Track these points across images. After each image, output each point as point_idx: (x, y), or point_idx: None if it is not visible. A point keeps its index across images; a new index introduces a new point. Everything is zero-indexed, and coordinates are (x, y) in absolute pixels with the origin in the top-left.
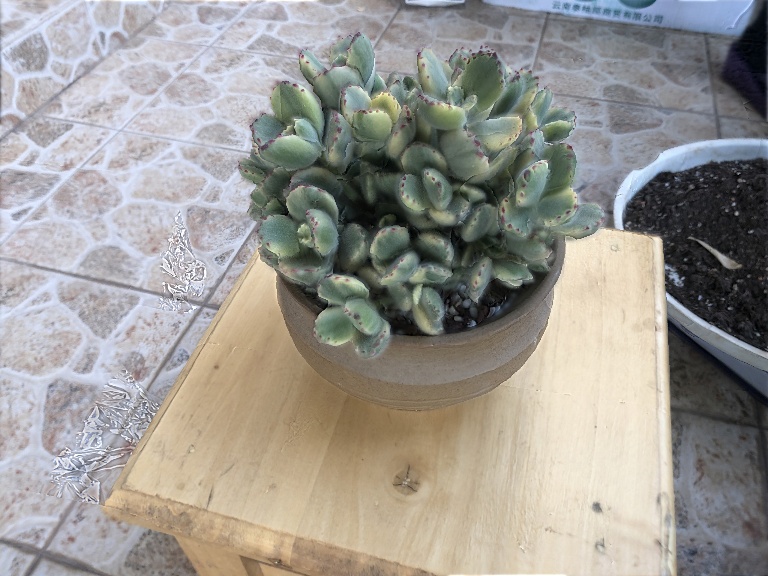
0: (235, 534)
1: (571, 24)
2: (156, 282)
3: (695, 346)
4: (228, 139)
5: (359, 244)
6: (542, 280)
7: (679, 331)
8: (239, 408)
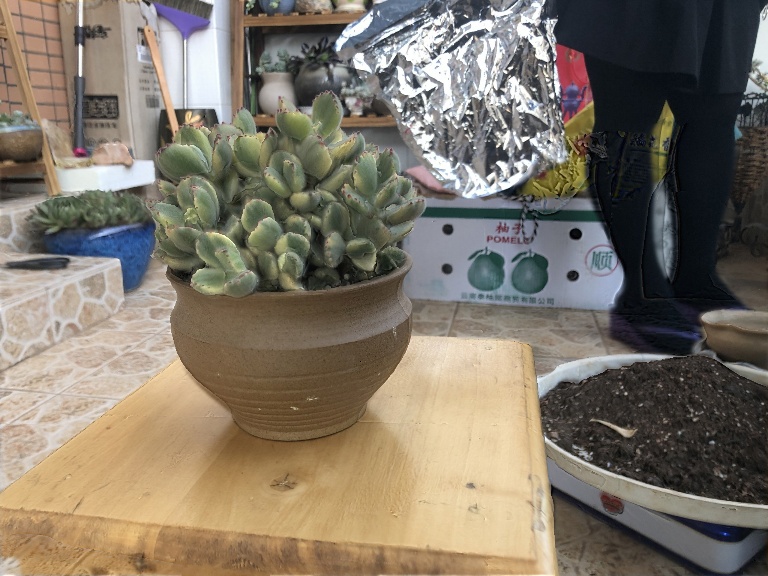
0: (98, 531)
1: (478, 308)
2: None
3: (623, 529)
4: None
5: (234, 224)
6: (391, 271)
7: (604, 516)
8: (124, 450)
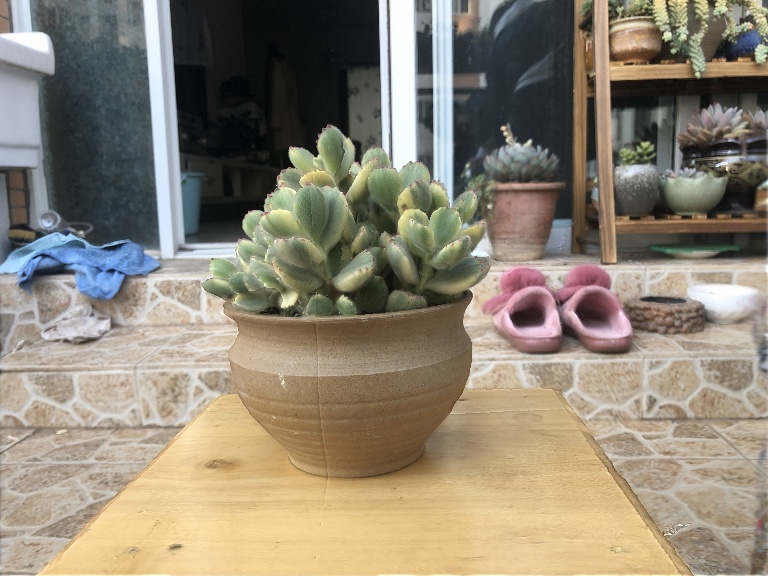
0: None
1: None
2: None
3: None
4: None
5: None
6: None
7: None
8: None
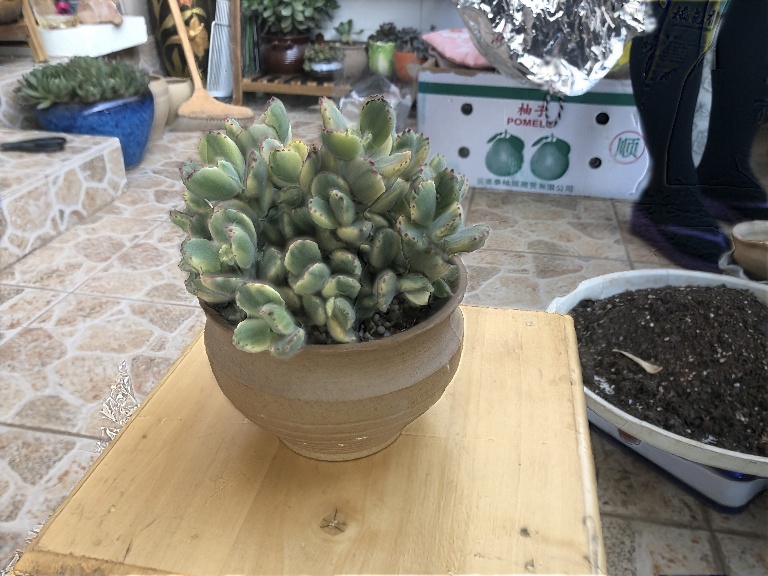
0: None
1: (494, 195)
2: (95, 427)
3: (636, 456)
4: (177, 296)
5: (275, 262)
6: (446, 302)
7: (619, 443)
8: (165, 470)
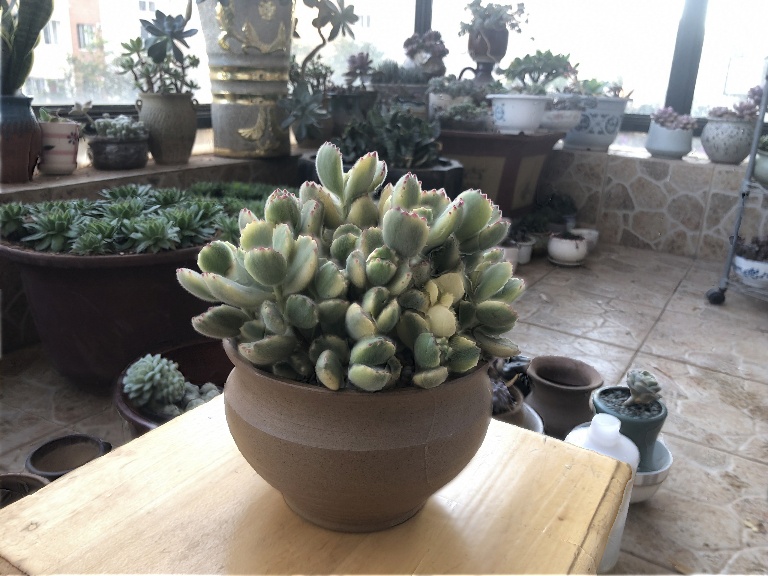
0: None
1: None
2: None
3: None
4: None
5: None
6: None
7: None
8: (531, 483)
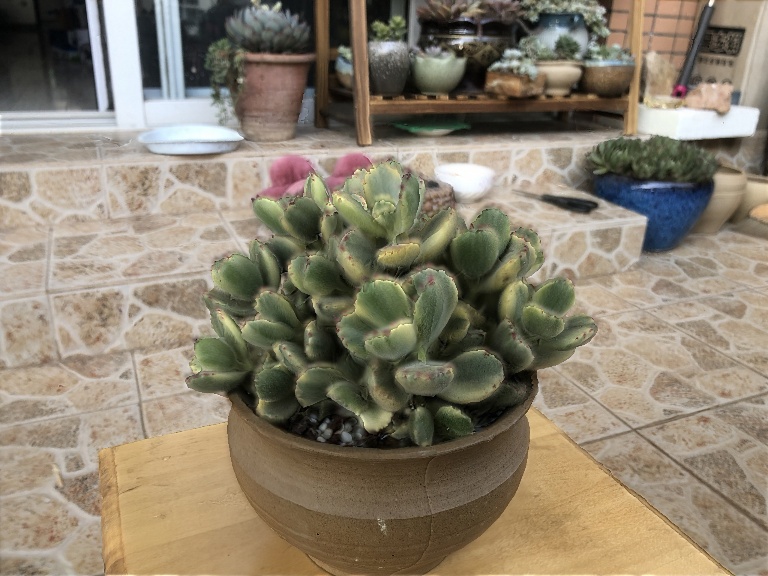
0: (108, 524)
1: None
2: None
3: None
4: (586, 380)
5: None
6: (401, 447)
7: None
8: (222, 459)
